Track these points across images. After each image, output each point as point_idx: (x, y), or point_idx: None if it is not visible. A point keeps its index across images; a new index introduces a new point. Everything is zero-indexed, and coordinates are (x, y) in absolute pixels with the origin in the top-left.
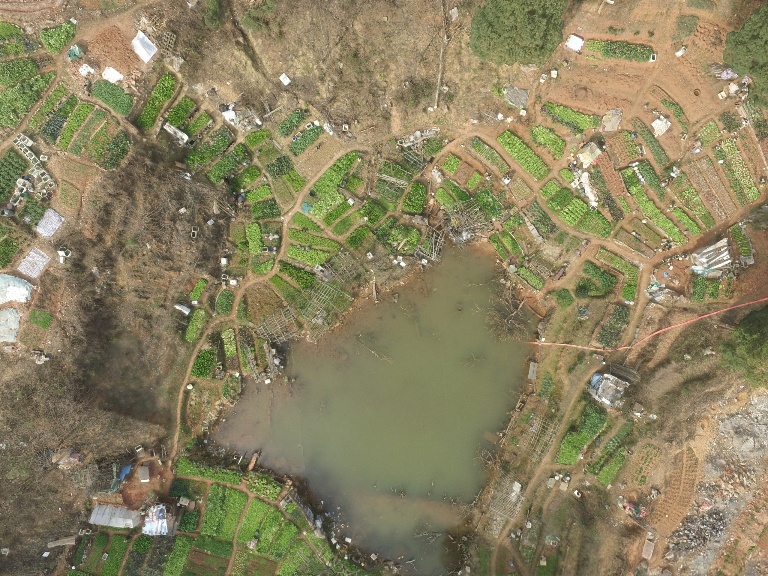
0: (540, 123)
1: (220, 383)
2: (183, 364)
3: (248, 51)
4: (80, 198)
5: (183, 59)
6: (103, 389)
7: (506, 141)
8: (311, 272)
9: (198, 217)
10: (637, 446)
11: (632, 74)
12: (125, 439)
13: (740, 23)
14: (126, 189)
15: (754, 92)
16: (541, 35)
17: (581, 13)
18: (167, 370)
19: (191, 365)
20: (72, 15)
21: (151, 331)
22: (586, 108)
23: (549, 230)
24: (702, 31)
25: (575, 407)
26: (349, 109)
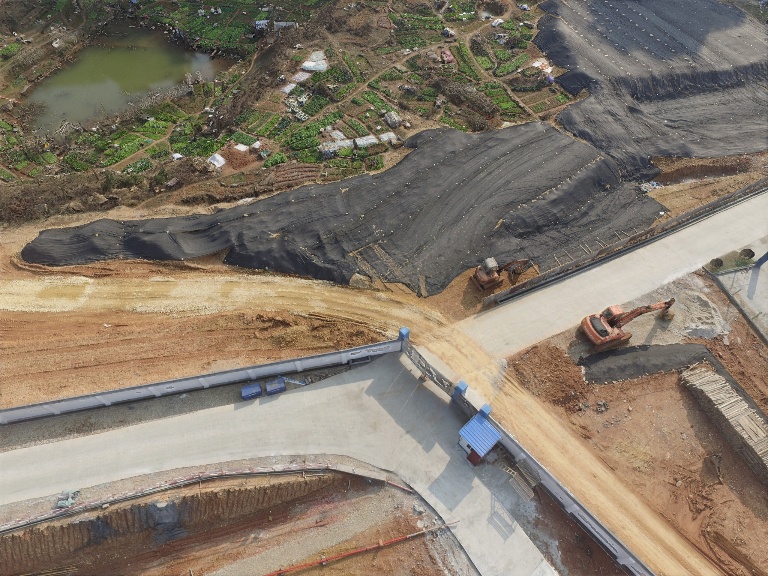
0: None
1: None
2: None
3: None
4: None
5: None
6: None
7: None
8: None
9: None
10: None
11: None
12: None
13: None
14: None
15: None
16: None
17: None
18: None
19: None
20: None
21: None
22: None
23: None
24: None
25: (0, 67)
26: None
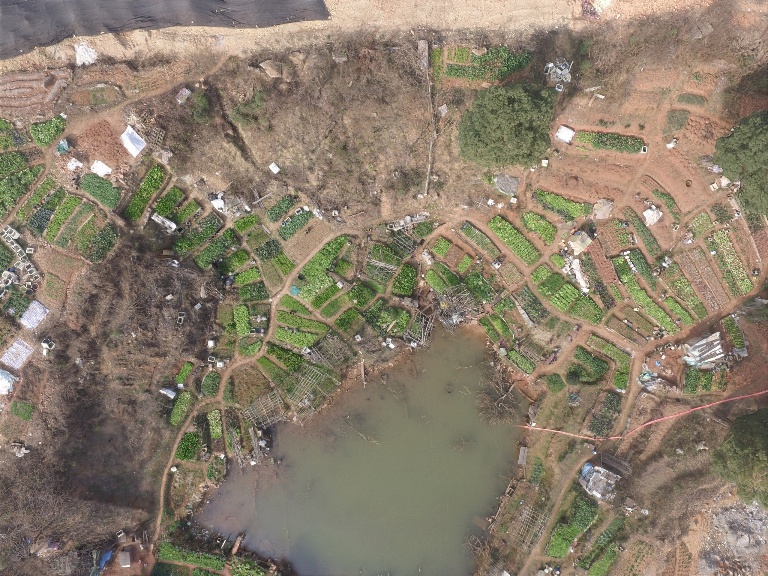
0: (531, 209)
1: (205, 465)
2: (167, 447)
3: (238, 142)
4: (65, 290)
5: (172, 153)
6: (84, 478)
7: (497, 226)
8: (299, 354)
9: (185, 302)
10: (628, 542)
11: (623, 164)
12: (106, 526)
13: (731, 118)
14: (112, 280)
15: (745, 196)
16: (528, 146)
17: (572, 106)
18: (151, 454)
19: (175, 447)
20: (62, 110)
21: (135, 416)
22: (577, 196)
23: (540, 315)
24: (693, 124)
25: (565, 497)
26: (339, 195)
